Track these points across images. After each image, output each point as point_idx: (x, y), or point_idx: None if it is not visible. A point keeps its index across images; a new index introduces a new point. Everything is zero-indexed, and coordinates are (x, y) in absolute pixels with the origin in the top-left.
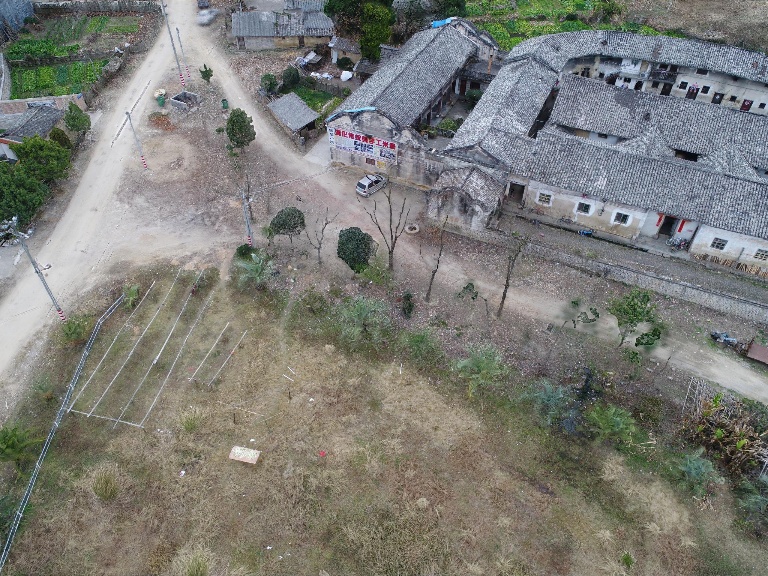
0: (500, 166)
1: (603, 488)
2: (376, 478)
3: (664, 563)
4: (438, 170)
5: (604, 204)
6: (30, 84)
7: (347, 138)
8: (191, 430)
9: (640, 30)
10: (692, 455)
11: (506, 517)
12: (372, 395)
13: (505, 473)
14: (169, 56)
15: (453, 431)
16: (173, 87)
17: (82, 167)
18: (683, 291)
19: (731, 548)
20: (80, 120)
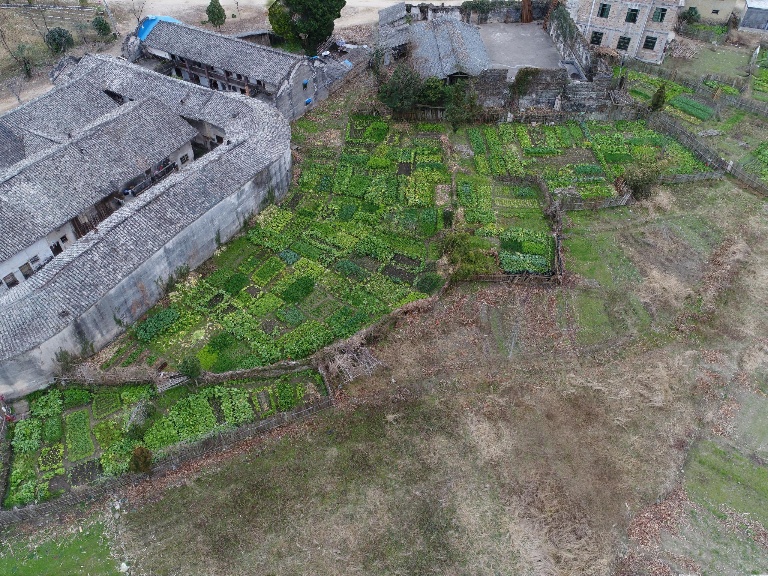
0: None
1: None
2: None
3: None
4: None
5: None
6: None
7: None
8: None
9: (417, 291)
10: None
11: None
12: None
13: None
14: (376, 5)
15: None
16: None
17: None
18: None
19: None
20: None
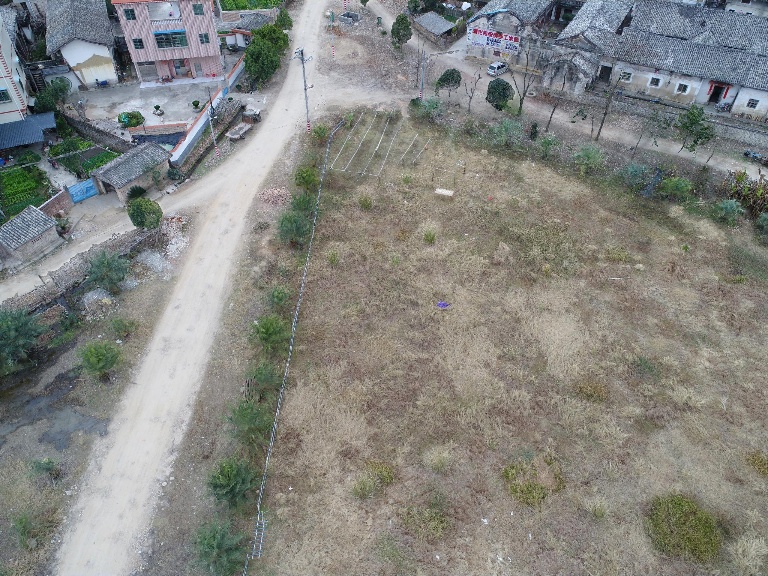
0: (596, 50)
1: (670, 221)
2: (526, 210)
3: (708, 252)
4: (549, 57)
5: (670, 77)
6: (232, 5)
7: (482, 35)
8: (407, 183)
9: None
10: (728, 200)
11: (609, 229)
12: (516, 175)
13: (607, 212)
14: None
15: (572, 192)
16: (337, 10)
17: (288, 55)
18: (725, 130)
19: (751, 248)
20: (288, 21)
